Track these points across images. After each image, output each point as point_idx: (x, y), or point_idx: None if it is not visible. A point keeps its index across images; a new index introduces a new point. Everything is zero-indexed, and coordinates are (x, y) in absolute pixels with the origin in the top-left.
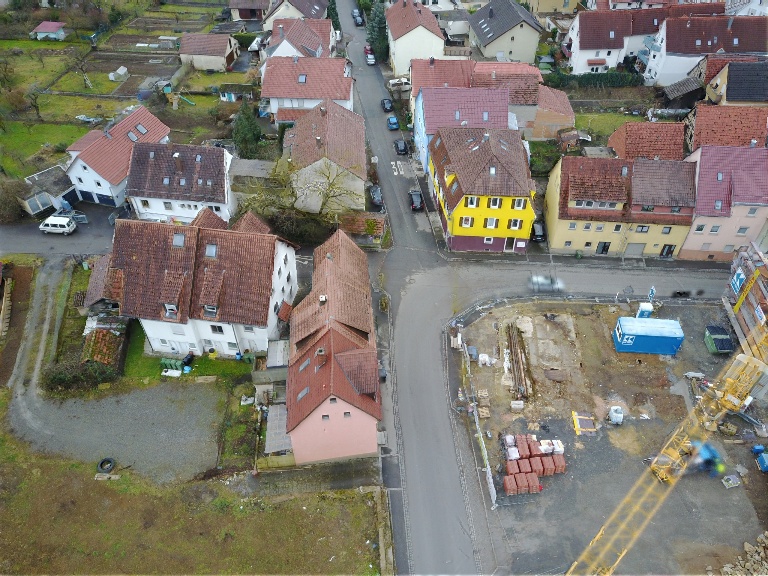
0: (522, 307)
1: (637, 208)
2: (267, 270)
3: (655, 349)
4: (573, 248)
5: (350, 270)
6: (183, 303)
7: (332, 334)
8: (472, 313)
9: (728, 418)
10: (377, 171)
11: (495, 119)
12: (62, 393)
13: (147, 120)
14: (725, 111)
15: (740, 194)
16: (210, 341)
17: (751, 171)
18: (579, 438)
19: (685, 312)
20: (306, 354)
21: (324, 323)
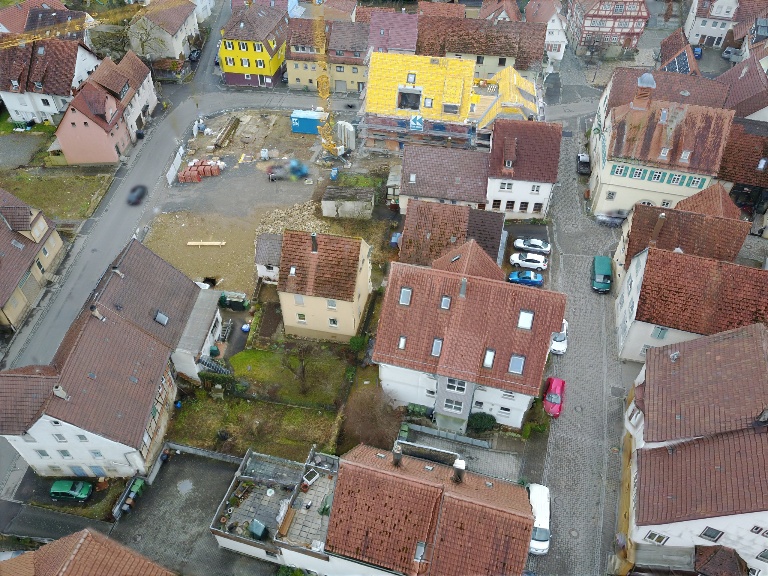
0: (251, 112)
1: (333, 53)
2: (72, 62)
3: (317, 132)
4: (302, 84)
5: (127, 69)
6: (22, 81)
7: (87, 84)
8: (218, 113)
9: (334, 161)
10: (206, 44)
11: (279, 6)
12: None
13: (51, 1)
14: (437, 6)
15: (392, 43)
16: (45, 113)
17: (401, 29)
18: (238, 164)
19: (351, 118)
20: None
21: (86, 81)
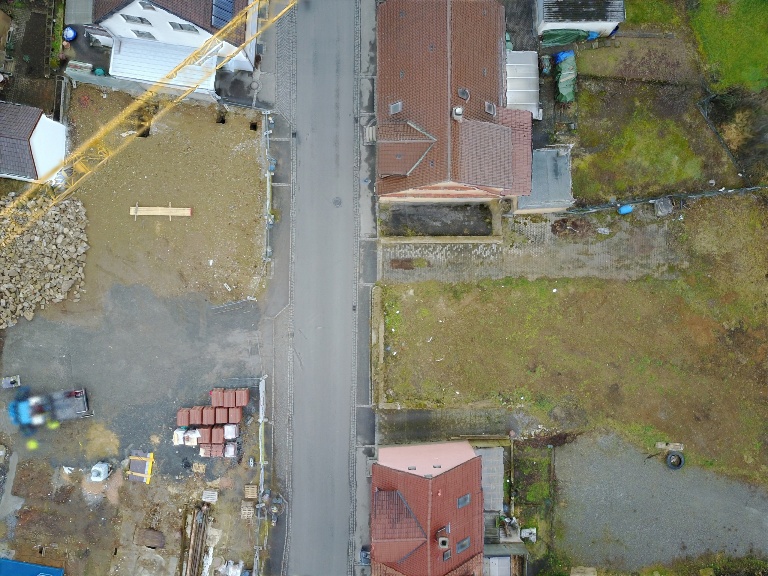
0: None
1: None
2: None
3: (13, 568)
4: None
5: None
6: None
7: (429, 575)
8: None
9: None
10: None
11: None
12: (756, 567)
13: None
14: None
15: None
16: None
17: None
18: (152, 448)
19: None
20: (462, 562)
21: None
